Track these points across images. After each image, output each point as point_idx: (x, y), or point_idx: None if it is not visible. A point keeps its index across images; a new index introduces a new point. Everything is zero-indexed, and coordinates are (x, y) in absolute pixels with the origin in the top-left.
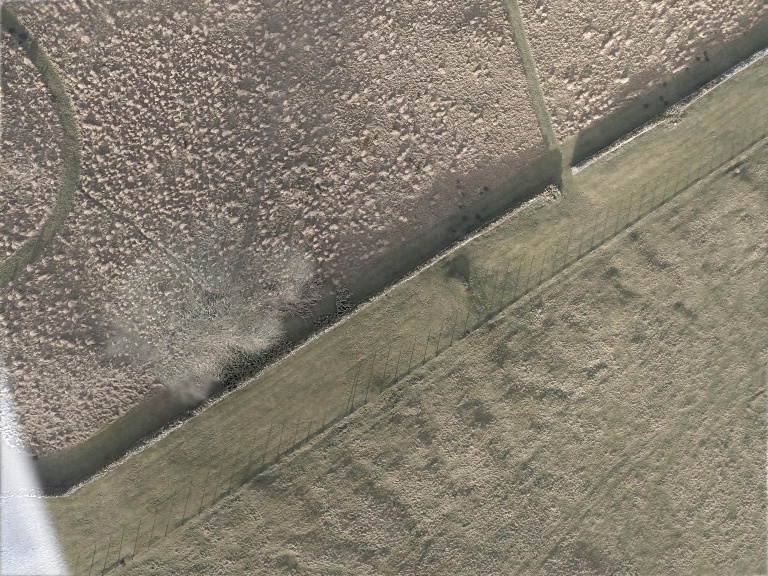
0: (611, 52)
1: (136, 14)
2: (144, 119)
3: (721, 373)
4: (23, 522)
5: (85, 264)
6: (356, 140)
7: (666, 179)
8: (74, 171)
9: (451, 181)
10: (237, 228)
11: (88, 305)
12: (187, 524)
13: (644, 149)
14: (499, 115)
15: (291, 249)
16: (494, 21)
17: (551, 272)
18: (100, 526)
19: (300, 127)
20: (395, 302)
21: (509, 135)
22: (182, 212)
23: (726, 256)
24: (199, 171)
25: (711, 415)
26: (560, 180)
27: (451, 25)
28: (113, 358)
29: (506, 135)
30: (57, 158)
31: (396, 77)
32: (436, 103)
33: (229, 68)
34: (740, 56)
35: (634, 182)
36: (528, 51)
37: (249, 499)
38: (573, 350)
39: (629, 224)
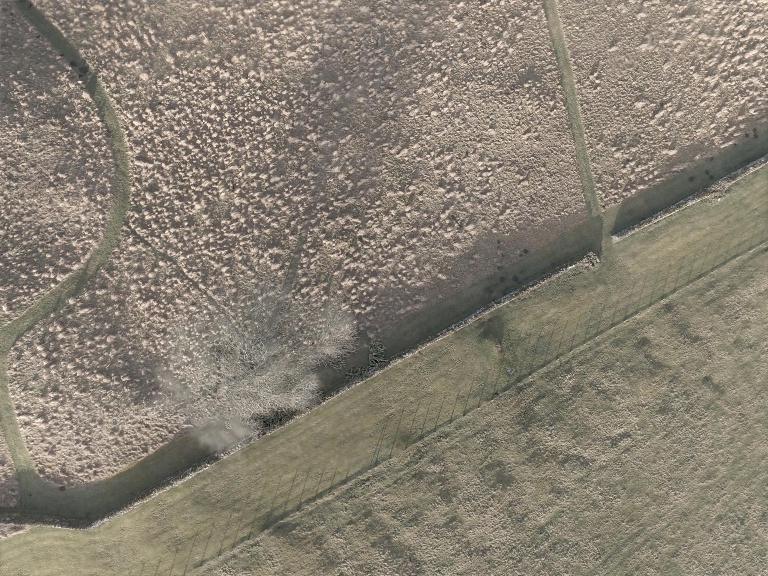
0: (661, 123)
1: (195, 55)
2: (195, 159)
3: (744, 450)
4: (45, 550)
5: (126, 300)
6: (402, 195)
7: (705, 253)
8: (122, 207)
9: (492, 241)
10: (278, 274)
11: (126, 341)
12: (206, 565)
13: (686, 222)
14: (545, 179)
15: (329, 299)
16: (547, 85)
17: (583, 338)
18: (120, 560)
19: (347, 178)
20: (427, 359)
21: (553, 199)
22: (225, 255)
23: (758, 334)
24: (245, 215)
25: (730, 491)
26: (600, 247)
27: (505, 86)
28: (147, 396)
29: (550, 199)
30: (107, 193)
31: (446, 134)
32: (483, 163)
33: (282, 114)
34: None
35: (673, 254)
36: (578, 117)
37: (268, 545)
38: (599, 418)
39: (664, 295)
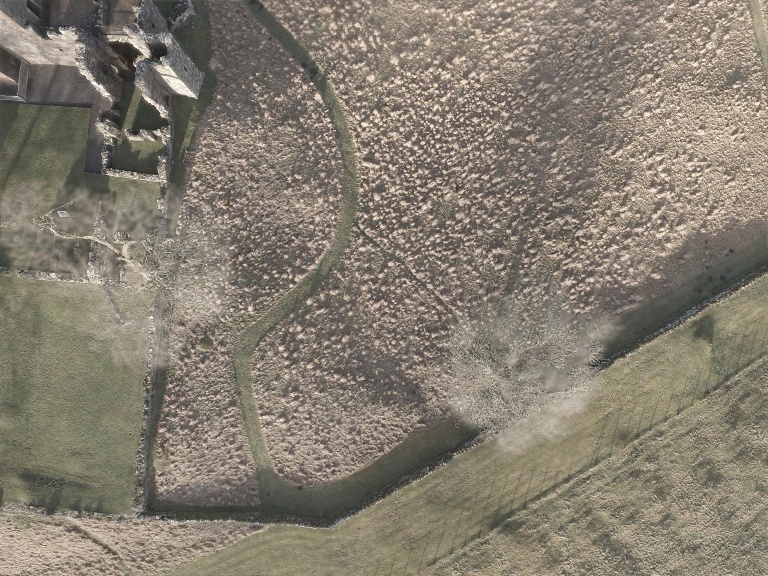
0: None
1: (418, 56)
2: (419, 161)
3: None
4: (283, 549)
5: (357, 300)
6: (616, 195)
7: None
8: (352, 207)
9: (700, 241)
10: (501, 275)
11: (359, 341)
12: (438, 563)
13: None
14: (749, 179)
15: (549, 299)
16: (753, 86)
17: None
18: (355, 559)
19: (566, 179)
20: (644, 358)
21: (757, 199)
22: (452, 255)
23: None
24: None
25: None
26: None
27: (714, 87)
28: (383, 396)
29: (754, 199)
30: (338, 194)
31: (657, 135)
32: (693, 163)
33: (501, 115)
34: None
35: None
36: None
37: (498, 543)
38: None
39: None
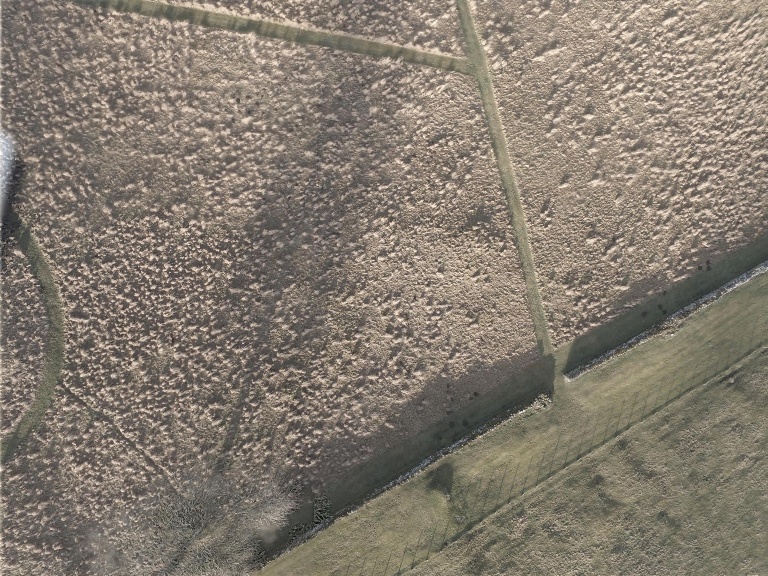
0: (613, 258)
1: (134, 204)
2: (133, 313)
3: None
4: None
5: (59, 462)
6: (347, 343)
7: (659, 387)
8: (56, 365)
9: (441, 386)
10: (218, 430)
11: (59, 506)
12: None
13: (639, 359)
14: (495, 320)
15: (272, 453)
16: (497, 225)
17: (535, 480)
18: None
19: (291, 328)
20: (374, 512)
21: (503, 340)
22: (163, 413)
23: (714, 465)
24: (184, 370)
25: None
26: (552, 386)
27: (453, 229)
28: (79, 566)
29: (500, 340)
30: (40, 352)
31: (393, 279)
32: (432, 307)
33: (224, 263)
34: (742, 266)
35: (626, 390)
36: (529, 255)
37: None
38: (552, 560)
39: (618, 432)
